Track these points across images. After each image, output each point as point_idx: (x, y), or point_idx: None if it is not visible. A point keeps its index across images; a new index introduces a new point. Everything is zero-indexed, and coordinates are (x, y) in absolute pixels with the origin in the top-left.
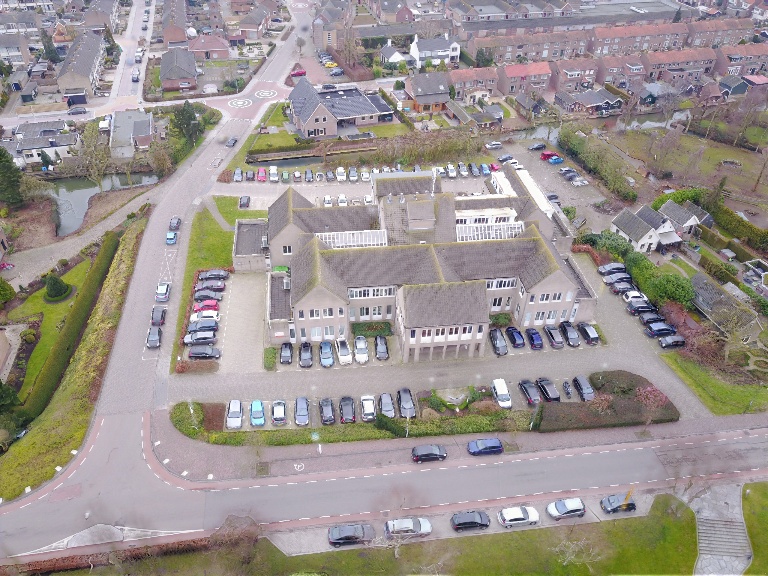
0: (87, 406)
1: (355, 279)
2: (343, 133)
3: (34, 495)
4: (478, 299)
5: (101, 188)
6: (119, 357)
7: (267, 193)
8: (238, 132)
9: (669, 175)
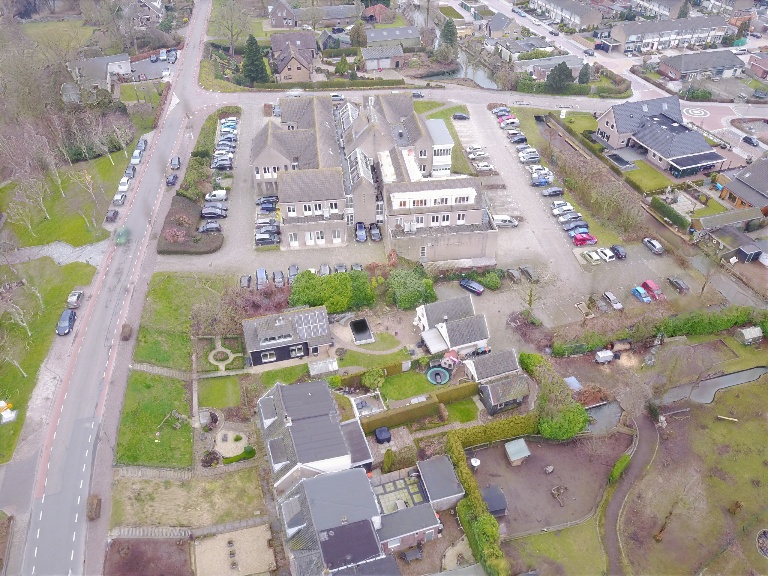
0: (245, 90)
1: (301, 120)
2: (623, 152)
3: (201, 89)
4: (260, 150)
5: (466, 74)
6: (281, 94)
7: (482, 126)
8: (591, 107)
9: (654, 413)
